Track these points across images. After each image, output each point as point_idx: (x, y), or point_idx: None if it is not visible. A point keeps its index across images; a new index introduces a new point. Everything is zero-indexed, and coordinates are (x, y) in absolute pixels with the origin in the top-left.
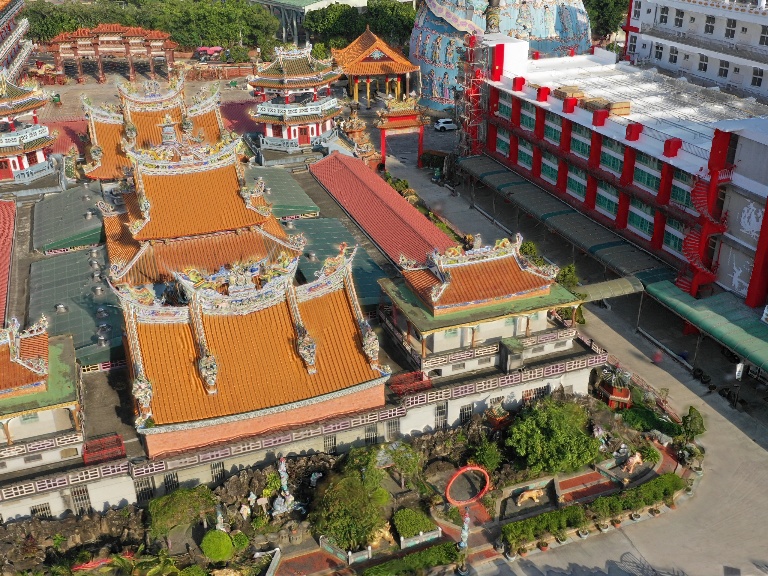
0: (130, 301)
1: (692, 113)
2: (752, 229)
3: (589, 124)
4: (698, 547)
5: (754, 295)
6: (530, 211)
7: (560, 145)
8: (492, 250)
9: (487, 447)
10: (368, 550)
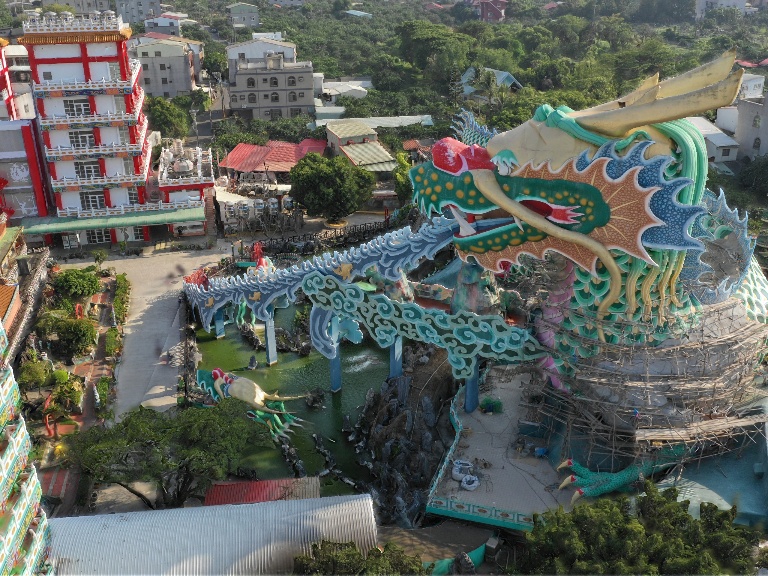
0: None
1: None
2: (22, 177)
3: None
4: (157, 285)
5: (44, 209)
6: None
7: None
8: None
9: (65, 301)
10: (93, 350)
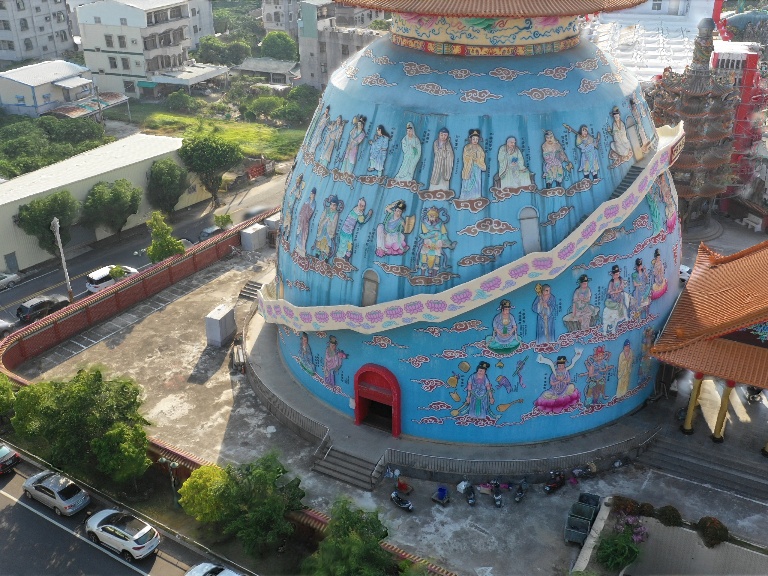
0: None
1: None
2: None
3: None
4: None
5: None
6: None
7: None
8: None
9: None
10: None
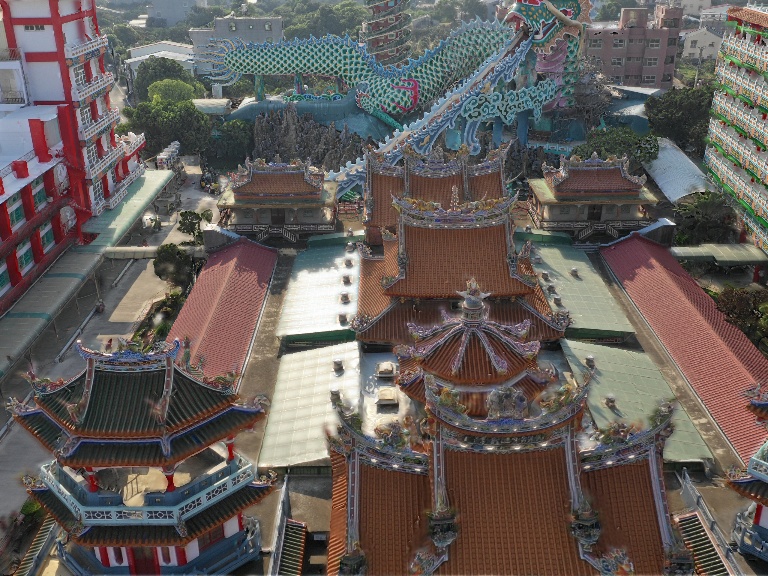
0: (501, 156)
1: None
2: None
3: None
4: None
5: None
6: None
7: None
8: (269, 165)
9: None
10: None
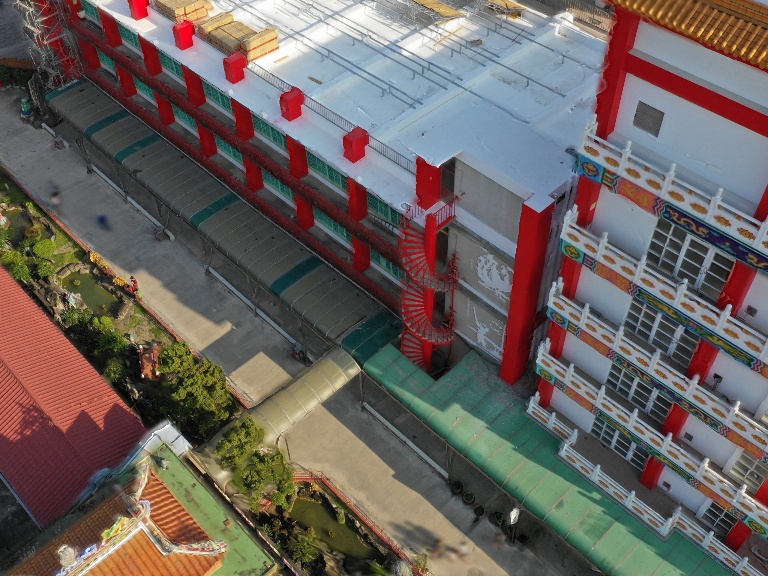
0: None
1: (368, 13)
2: (495, 287)
3: (221, 79)
4: None
5: (511, 373)
6: (172, 208)
7: (188, 94)
8: (100, 547)
9: None
10: None
